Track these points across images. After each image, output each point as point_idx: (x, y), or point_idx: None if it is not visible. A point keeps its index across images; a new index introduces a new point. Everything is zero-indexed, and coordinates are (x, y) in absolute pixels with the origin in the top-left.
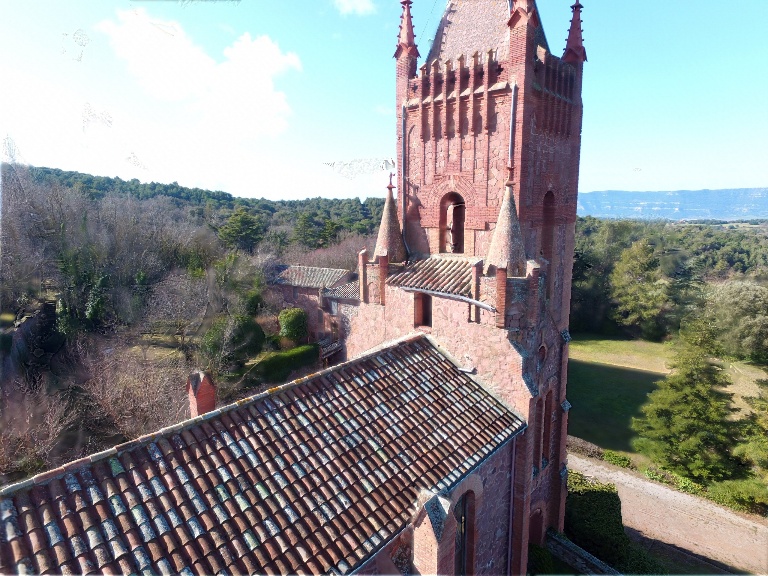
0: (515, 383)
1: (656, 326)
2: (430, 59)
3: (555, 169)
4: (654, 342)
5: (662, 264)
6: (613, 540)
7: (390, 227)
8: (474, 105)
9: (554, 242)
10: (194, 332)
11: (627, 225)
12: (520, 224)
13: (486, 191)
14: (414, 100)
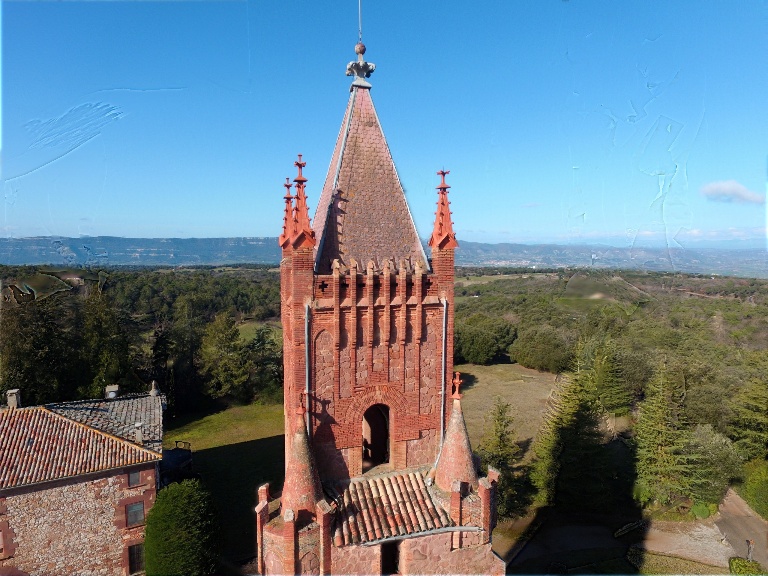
0: None
1: (245, 390)
2: (327, 249)
3: None
4: (245, 405)
5: (241, 333)
6: None
7: (312, 465)
8: (406, 315)
9: None
10: None
11: (205, 299)
12: None
13: (419, 400)
14: (325, 301)
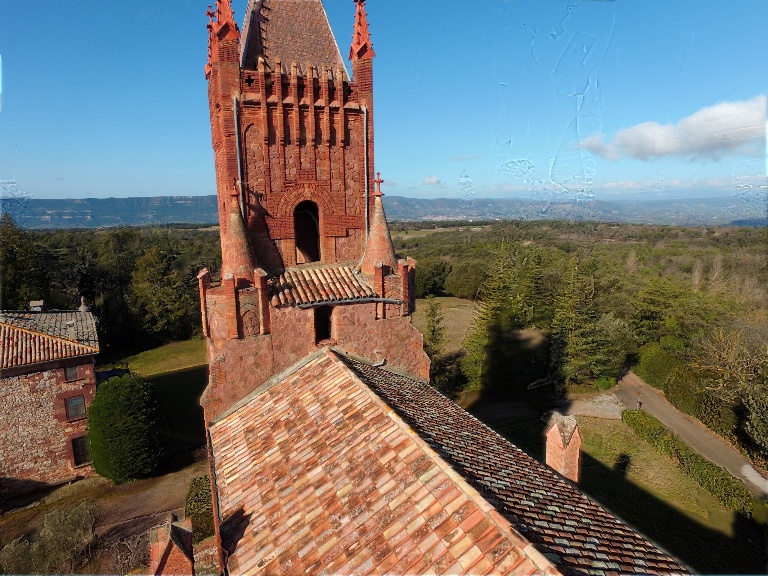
0: (419, 357)
1: (183, 325)
2: (251, 51)
3: None
4: (184, 340)
5: (174, 268)
6: None
7: (248, 242)
8: (329, 117)
9: None
10: None
11: (131, 233)
12: None
13: (344, 200)
14: (252, 95)
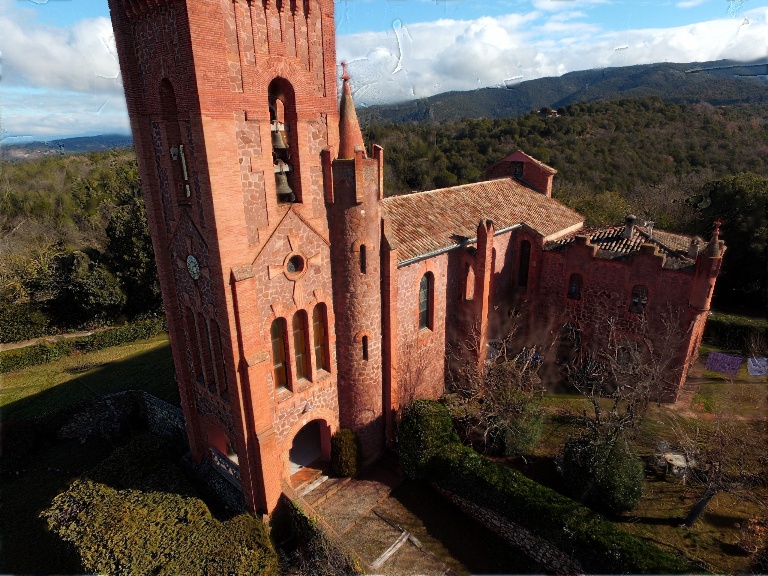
0: None
1: None
2: None
3: None
4: None
5: None
6: None
7: None
8: None
9: None
10: None
11: None
12: None
13: None
14: None
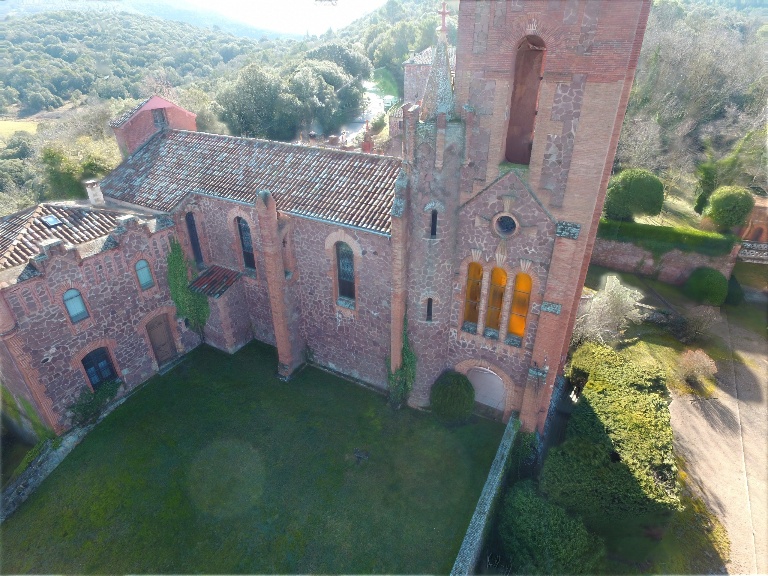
0: None
1: None
2: None
3: (552, 4)
4: None
5: None
6: (543, 471)
7: None
8: None
9: (544, 103)
10: (676, 189)
11: None
12: (459, 72)
13: None
14: None
